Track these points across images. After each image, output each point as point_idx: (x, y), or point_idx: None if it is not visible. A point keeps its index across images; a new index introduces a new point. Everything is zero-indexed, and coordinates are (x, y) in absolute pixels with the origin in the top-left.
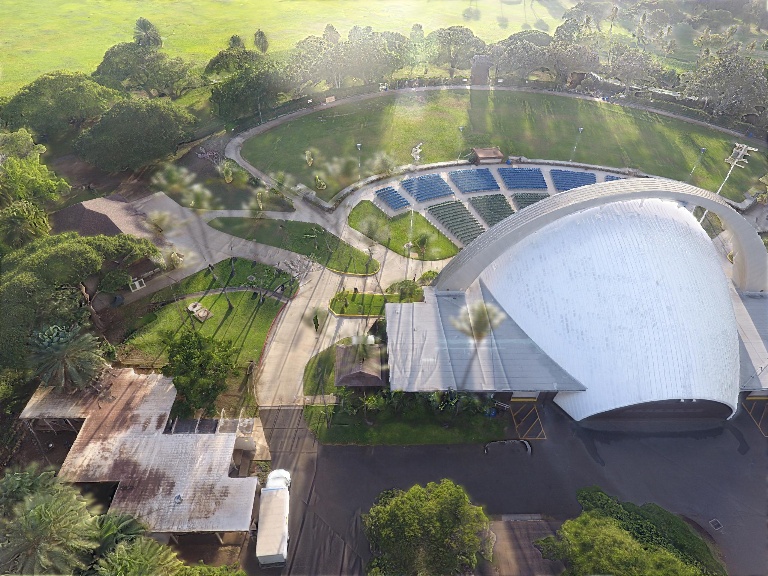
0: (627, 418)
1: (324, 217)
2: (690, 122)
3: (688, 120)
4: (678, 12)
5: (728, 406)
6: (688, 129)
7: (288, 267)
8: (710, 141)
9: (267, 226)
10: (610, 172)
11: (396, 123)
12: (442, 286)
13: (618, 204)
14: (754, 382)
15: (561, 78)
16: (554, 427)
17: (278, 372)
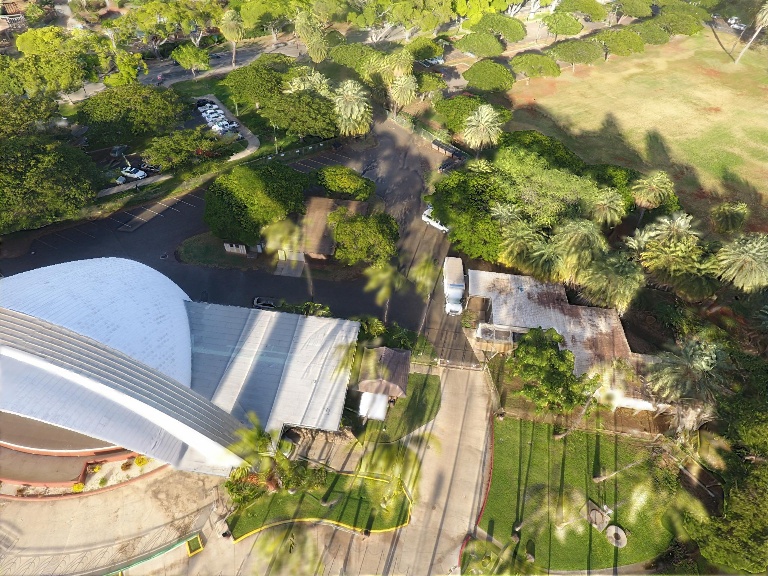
0: None
1: None
2: None
3: None
4: None
5: None
6: None
7: None
8: None
9: None
10: None
11: None
12: None
13: None
14: None
15: None
16: None
17: (470, 406)
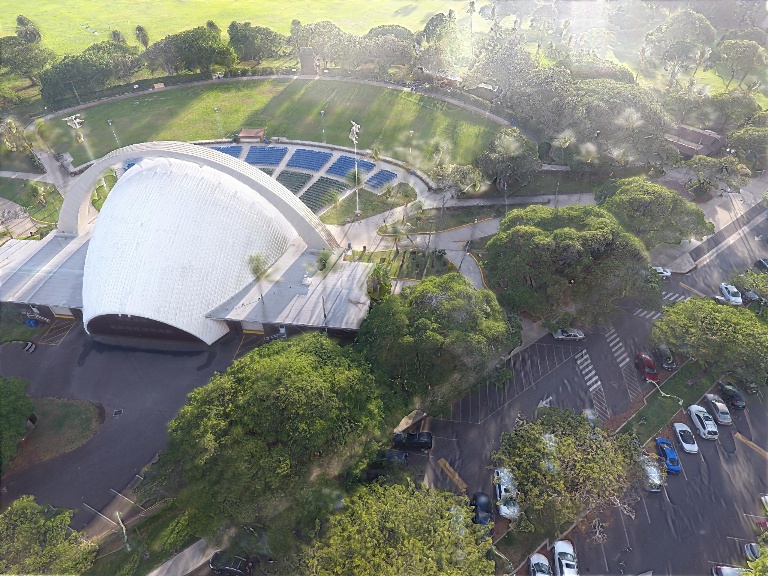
0: (129, 336)
1: (64, 179)
2: (471, 111)
3: (471, 109)
4: (596, 6)
5: (173, 326)
6: (462, 117)
7: (2, 215)
8: (471, 128)
9: (14, 184)
10: (351, 153)
11: (199, 106)
12: (58, 229)
13: (165, 164)
14: (223, 313)
15: (380, 69)
16: (73, 338)
17: None
